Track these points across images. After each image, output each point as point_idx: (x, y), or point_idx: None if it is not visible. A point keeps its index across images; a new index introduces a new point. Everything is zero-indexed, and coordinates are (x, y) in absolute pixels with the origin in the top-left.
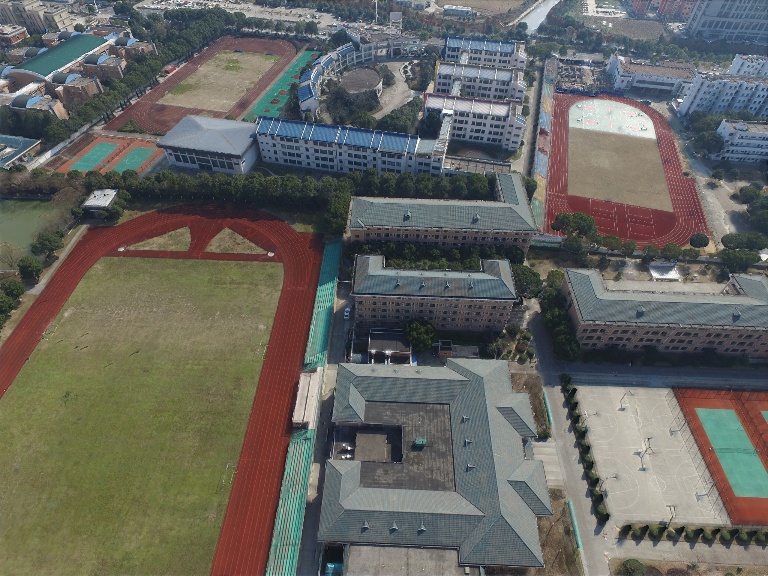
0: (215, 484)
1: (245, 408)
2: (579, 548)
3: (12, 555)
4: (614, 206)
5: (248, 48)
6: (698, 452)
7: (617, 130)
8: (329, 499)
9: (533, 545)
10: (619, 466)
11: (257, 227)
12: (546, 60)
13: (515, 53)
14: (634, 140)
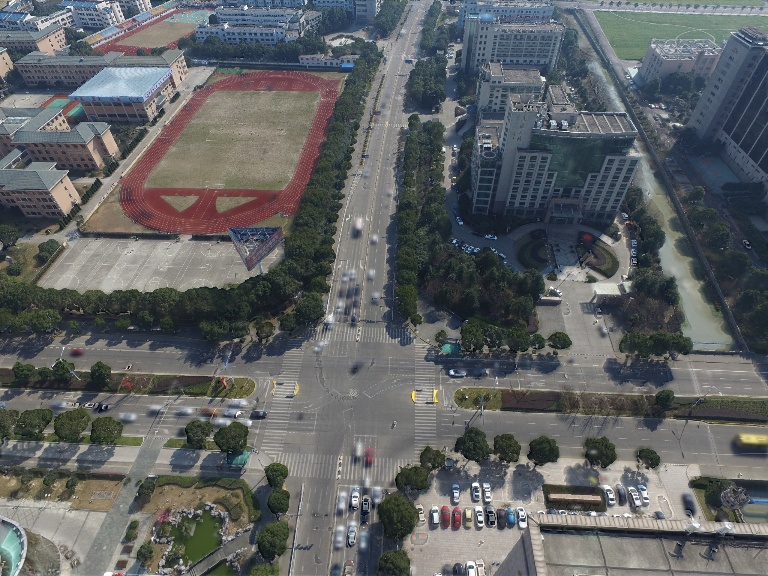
0: None
1: None
2: None
3: None
4: (130, 47)
5: None
6: None
7: (187, 21)
8: None
9: None
10: None
11: None
12: None
13: None
14: (190, 25)
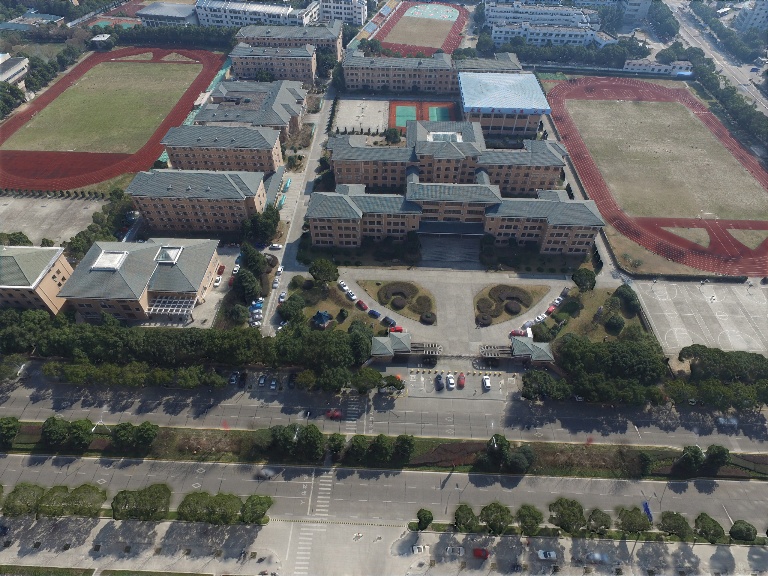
0: (154, 122)
1: (172, 104)
2: (314, 136)
3: (62, 136)
4: (406, 46)
5: None
6: (388, 116)
7: (433, 17)
8: (201, 110)
9: (284, 119)
10: (347, 119)
11: (192, 52)
12: None
13: None
14: (440, 21)
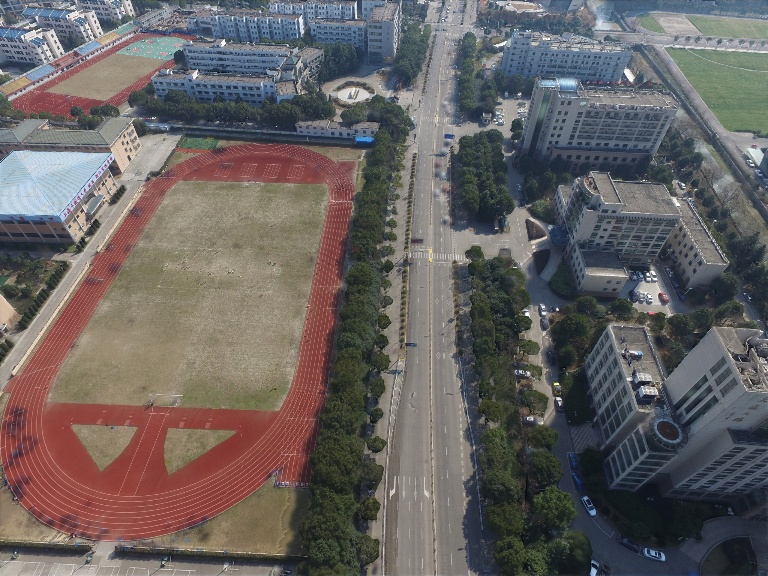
0: None
1: None
2: None
3: None
4: (66, 98)
5: None
6: None
7: (147, 55)
8: None
9: None
10: None
11: None
12: (153, 10)
13: (106, 1)
14: (150, 61)
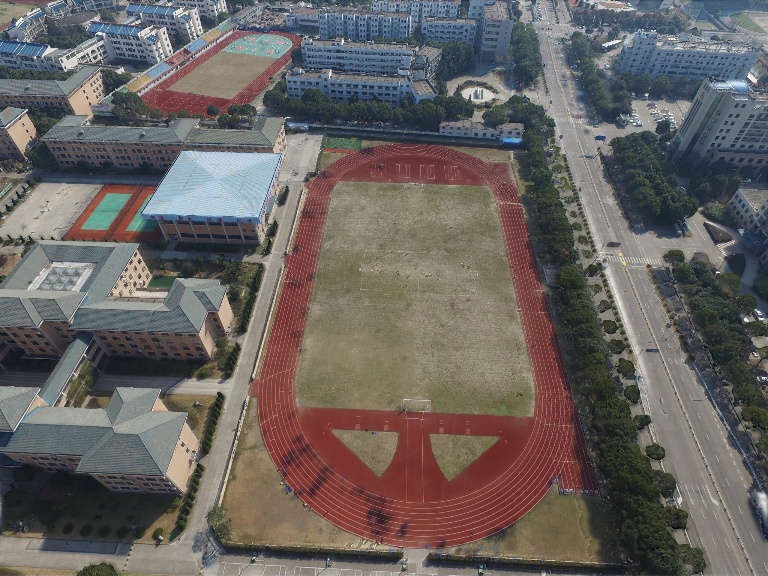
0: None
1: None
2: None
3: None
4: (191, 96)
5: (23, 1)
6: (82, 211)
7: (254, 53)
8: None
9: None
10: (23, 217)
11: None
12: (246, 7)
13: None
14: (260, 59)
